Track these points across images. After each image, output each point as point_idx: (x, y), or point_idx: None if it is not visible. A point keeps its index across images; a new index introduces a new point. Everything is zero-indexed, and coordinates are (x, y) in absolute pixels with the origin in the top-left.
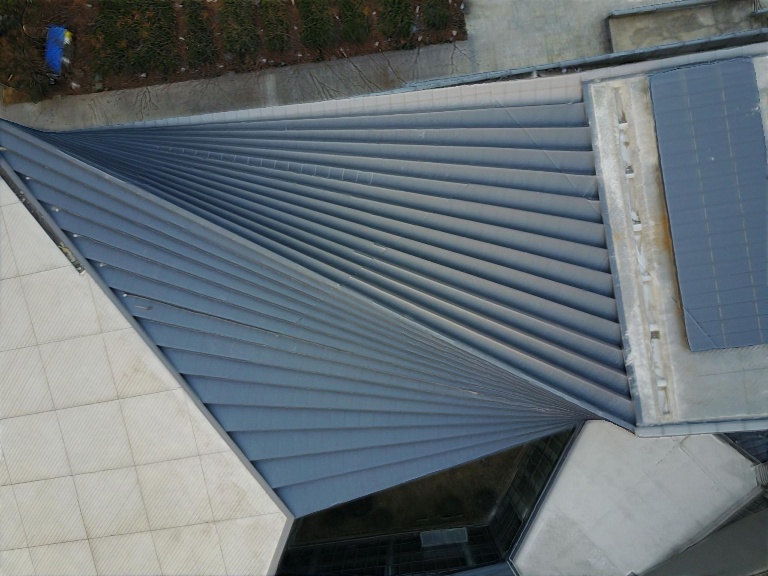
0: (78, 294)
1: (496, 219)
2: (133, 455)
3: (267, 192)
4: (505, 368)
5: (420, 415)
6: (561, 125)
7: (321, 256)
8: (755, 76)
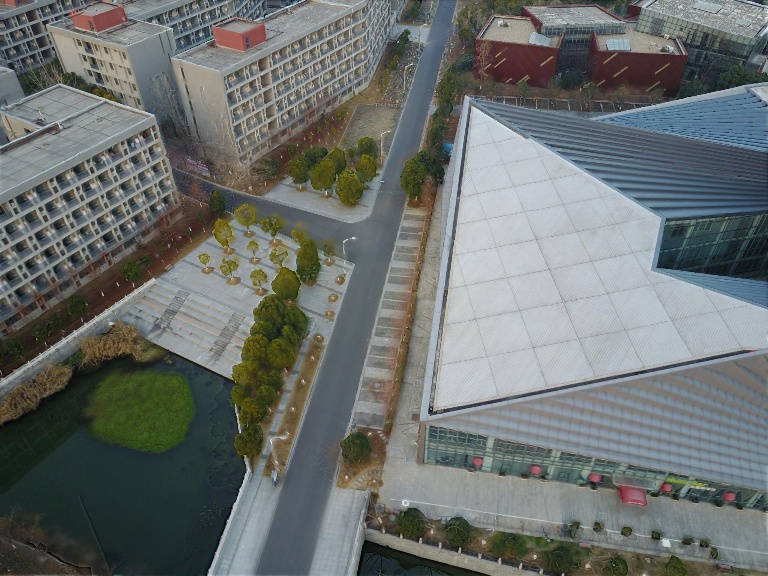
0: (526, 146)
1: None
2: (562, 200)
3: None
4: (761, 151)
5: (719, 189)
6: None
7: None
8: None
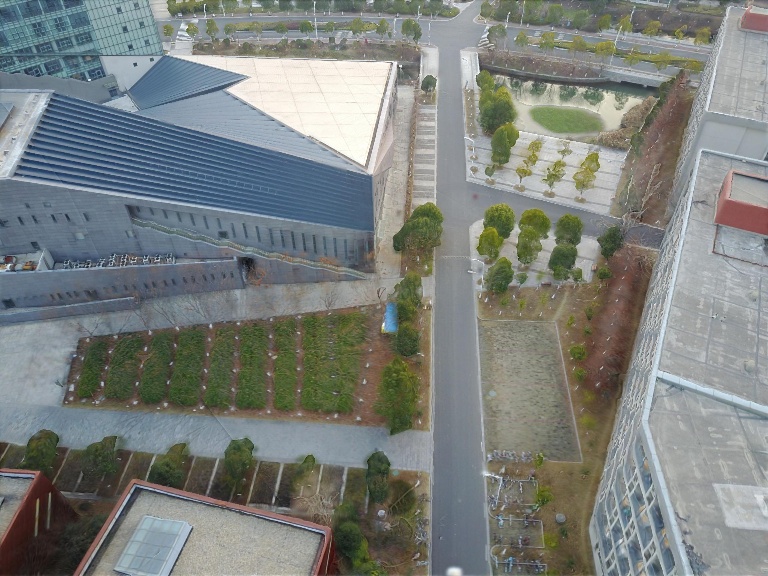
0: None
1: None
2: None
3: (208, 163)
4: None
5: None
6: (33, 169)
7: None
8: None
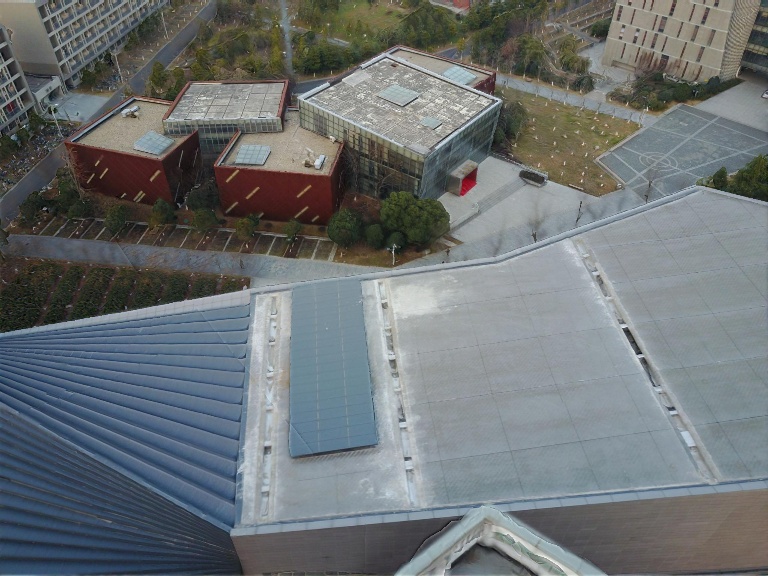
0: None
1: (169, 375)
2: None
3: (6, 363)
4: (130, 476)
5: (50, 548)
6: None
7: (17, 396)
8: (360, 286)
